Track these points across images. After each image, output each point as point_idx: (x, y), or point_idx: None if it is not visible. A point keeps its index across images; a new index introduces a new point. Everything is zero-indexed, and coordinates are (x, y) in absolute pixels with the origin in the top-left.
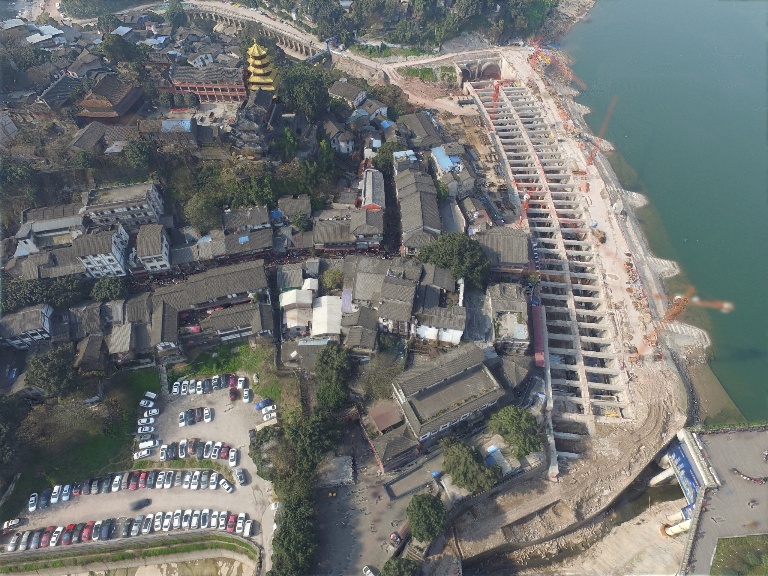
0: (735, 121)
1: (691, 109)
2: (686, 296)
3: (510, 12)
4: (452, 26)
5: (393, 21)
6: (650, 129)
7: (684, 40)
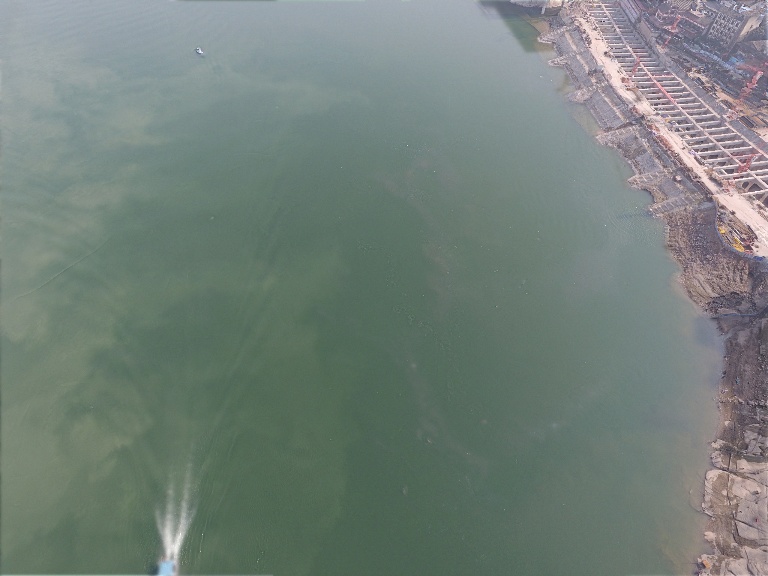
0: (464, 175)
1: (508, 192)
2: (546, 53)
3: None
4: None
5: None
6: (558, 164)
7: (480, 362)
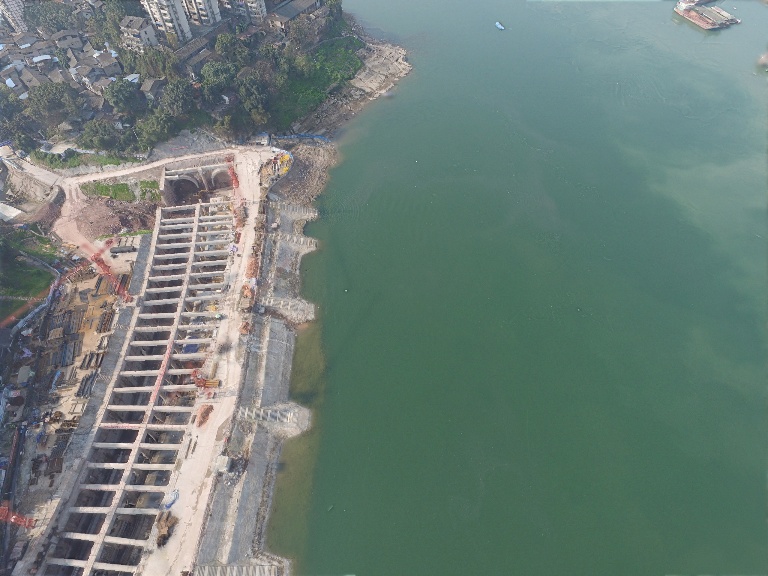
0: (501, 263)
1: (452, 242)
2: None
3: (243, 104)
4: (157, 127)
5: (85, 119)
6: (383, 278)
7: (492, 126)
